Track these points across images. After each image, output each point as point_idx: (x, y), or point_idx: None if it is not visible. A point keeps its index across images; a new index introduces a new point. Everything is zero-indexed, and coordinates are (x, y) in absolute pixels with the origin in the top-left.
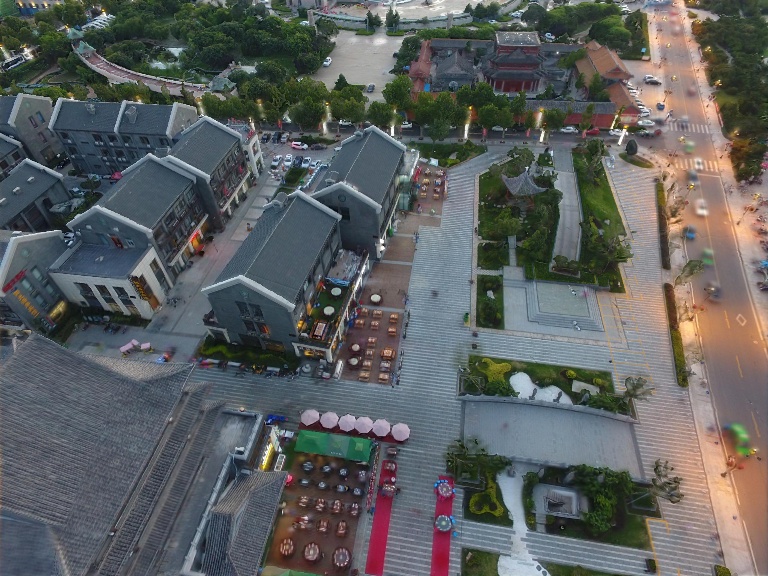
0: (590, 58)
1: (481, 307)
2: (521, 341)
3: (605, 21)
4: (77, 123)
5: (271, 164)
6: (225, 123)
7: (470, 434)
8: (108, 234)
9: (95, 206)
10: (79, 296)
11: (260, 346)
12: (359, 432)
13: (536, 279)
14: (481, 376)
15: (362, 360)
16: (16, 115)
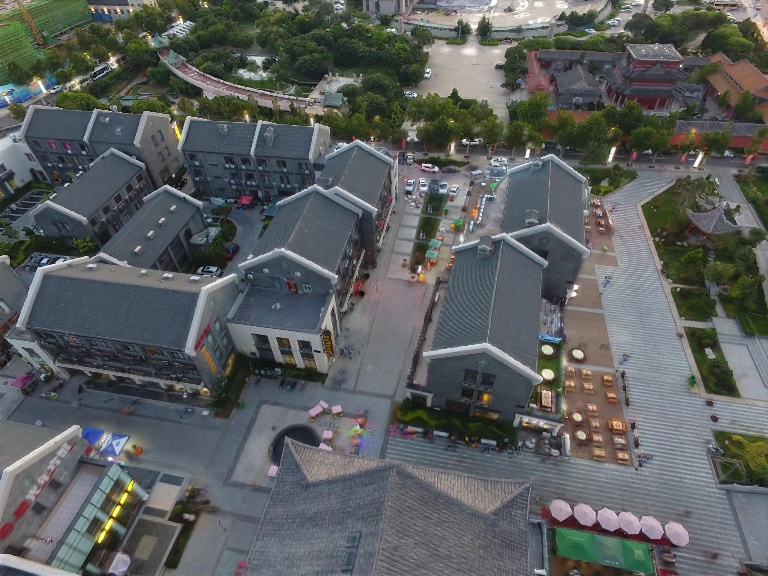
0: (727, 73)
1: (709, 369)
2: (767, 413)
3: (721, 31)
4: (208, 144)
5: (405, 189)
6: (344, 142)
7: (753, 536)
8: (285, 278)
9: (281, 249)
10: (251, 347)
11: (467, 412)
12: (627, 533)
13: (758, 335)
14: (737, 458)
15: (589, 433)
16: (141, 135)
